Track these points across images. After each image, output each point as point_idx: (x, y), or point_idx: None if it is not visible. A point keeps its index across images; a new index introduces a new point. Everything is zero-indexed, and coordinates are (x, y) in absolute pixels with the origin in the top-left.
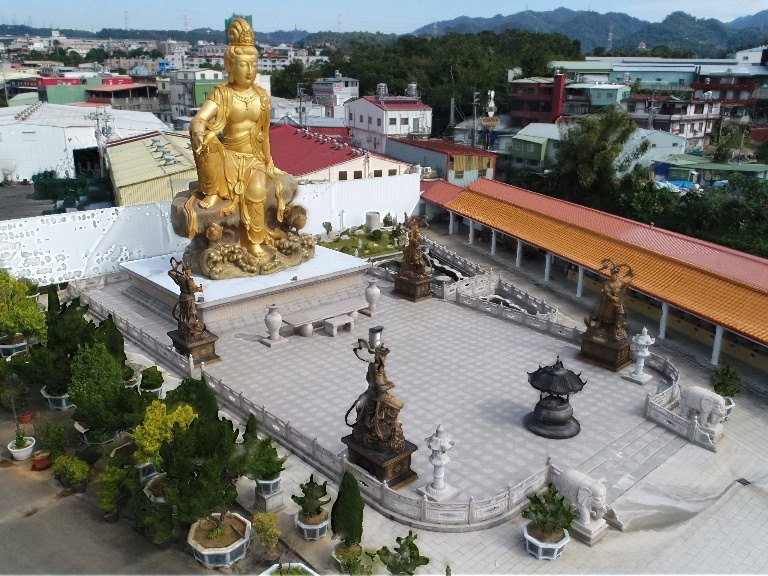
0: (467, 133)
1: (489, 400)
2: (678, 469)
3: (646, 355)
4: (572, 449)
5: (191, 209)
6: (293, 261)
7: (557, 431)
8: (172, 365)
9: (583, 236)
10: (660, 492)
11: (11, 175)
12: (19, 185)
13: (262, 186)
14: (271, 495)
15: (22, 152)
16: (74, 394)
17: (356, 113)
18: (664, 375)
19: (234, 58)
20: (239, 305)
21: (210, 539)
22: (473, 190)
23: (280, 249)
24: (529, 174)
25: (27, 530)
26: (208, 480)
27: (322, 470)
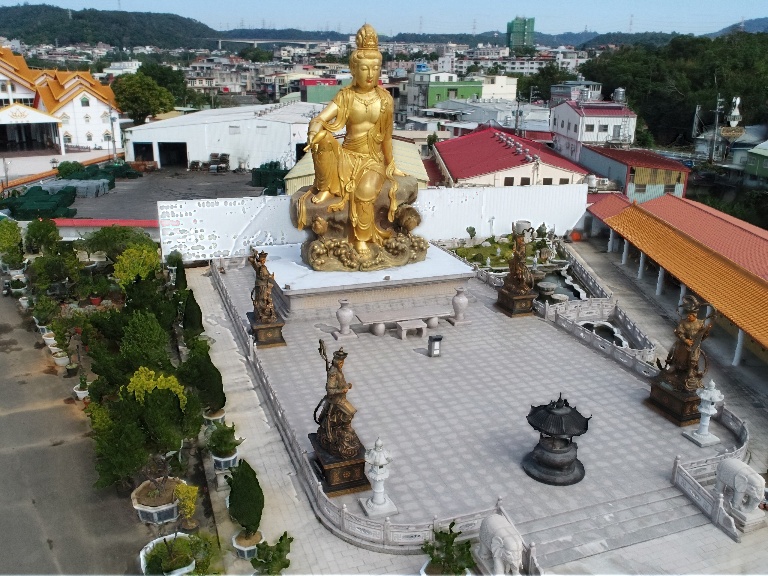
0: (705, 144)
1: (506, 429)
2: (672, 549)
3: (710, 413)
4: (554, 498)
5: (302, 203)
6: (398, 261)
7: (550, 475)
8: (244, 343)
9: (722, 268)
10: (627, 568)
11: (245, 163)
12: (249, 173)
13: (372, 186)
14: (223, 472)
15: (255, 144)
16: None
17: (559, 118)
18: (739, 441)
19: (356, 62)
20: (328, 297)
21: (148, 497)
22: (637, 206)
23: (387, 248)
24: (761, 194)
25: (45, 456)
26: (130, 442)
27: (293, 461)
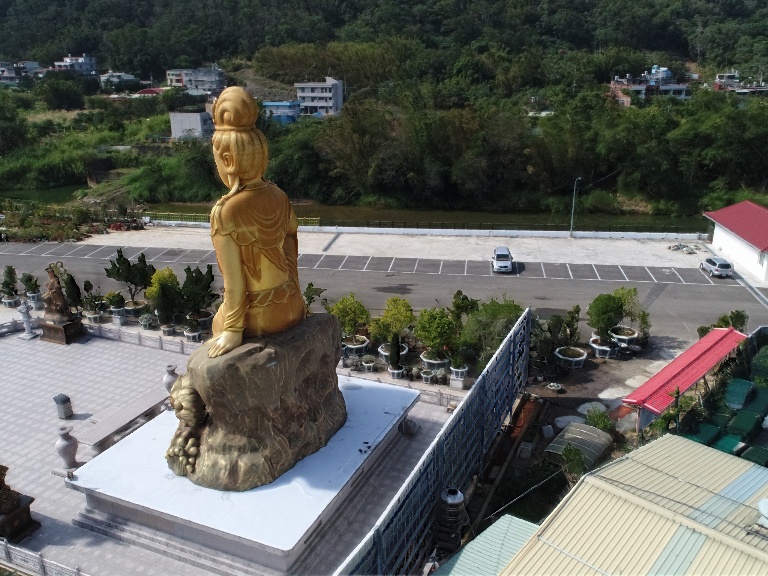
0: None
1: None
2: None
3: None
4: None
5: None
6: None
7: None
8: None
9: None
10: None
11: None
12: None
13: None
14: None
15: None
16: None
17: None
18: None
19: None
20: None
21: None
22: None
23: None
24: None
25: None
26: None
27: None
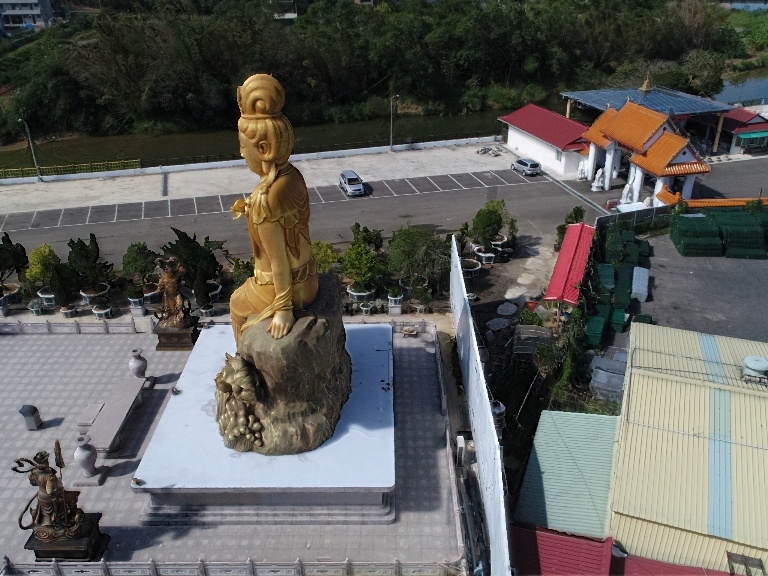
0: None
1: None
2: None
3: None
4: None
5: None
6: None
7: None
8: None
9: None
10: None
11: None
12: None
13: None
14: None
15: None
16: (92, 234)
17: None
18: None
19: None
20: None
21: None
22: None
23: None
24: None
25: None
26: None
27: None
